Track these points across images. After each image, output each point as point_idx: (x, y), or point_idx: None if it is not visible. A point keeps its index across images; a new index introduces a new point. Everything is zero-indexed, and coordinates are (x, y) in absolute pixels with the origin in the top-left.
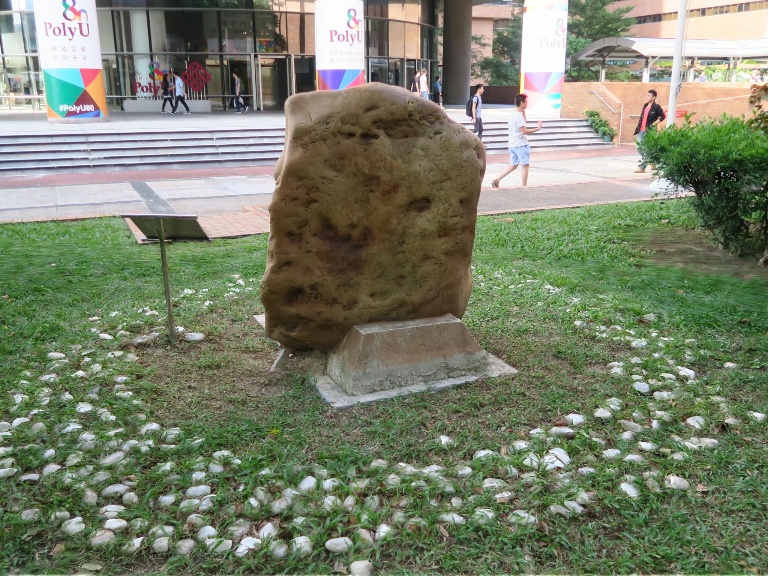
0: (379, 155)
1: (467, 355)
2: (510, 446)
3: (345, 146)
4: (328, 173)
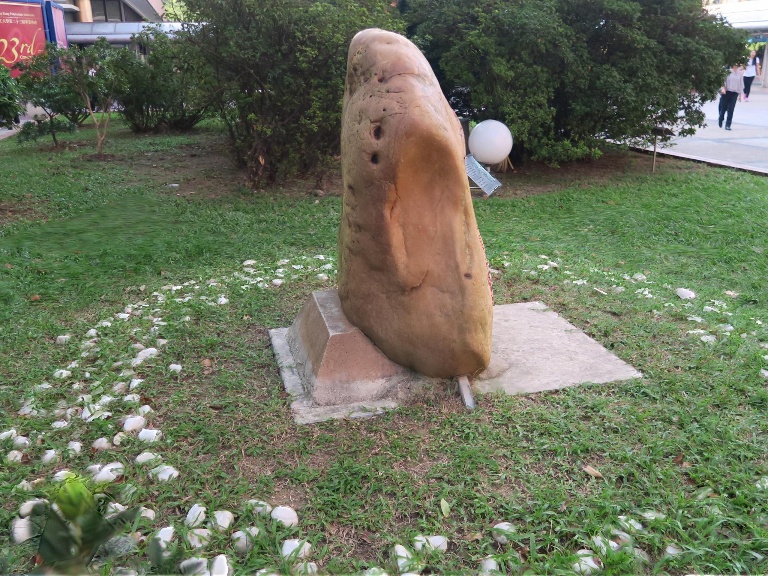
0: None
1: None
2: None
3: None
4: None
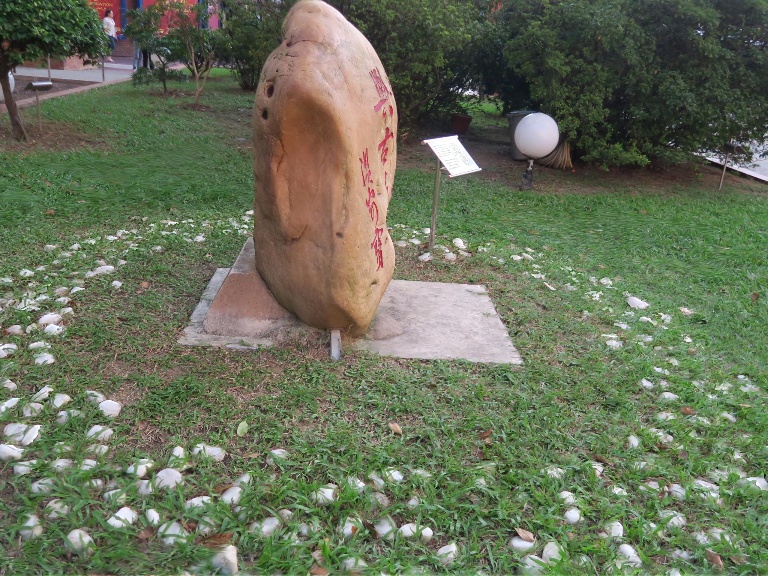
0: None
1: None
2: None
3: None
4: None
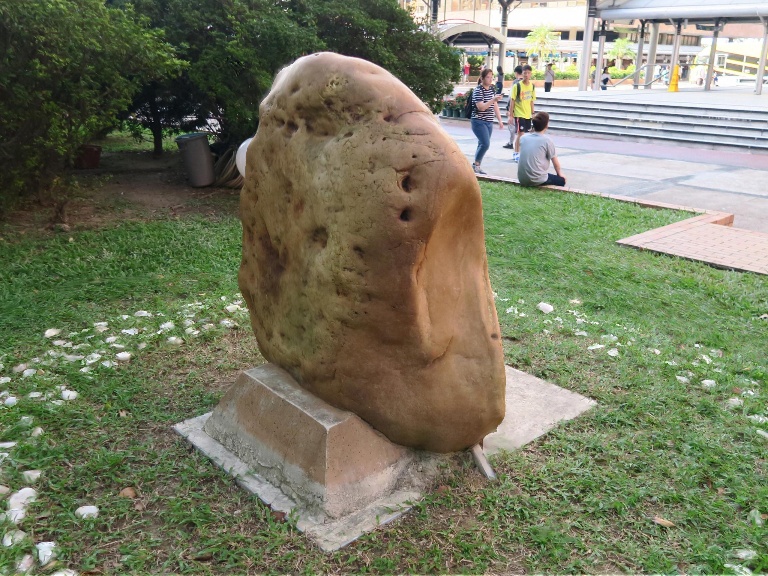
0: (293, 154)
1: (307, 476)
2: (58, 567)
3: (275, 136)
4: (264, 167)
